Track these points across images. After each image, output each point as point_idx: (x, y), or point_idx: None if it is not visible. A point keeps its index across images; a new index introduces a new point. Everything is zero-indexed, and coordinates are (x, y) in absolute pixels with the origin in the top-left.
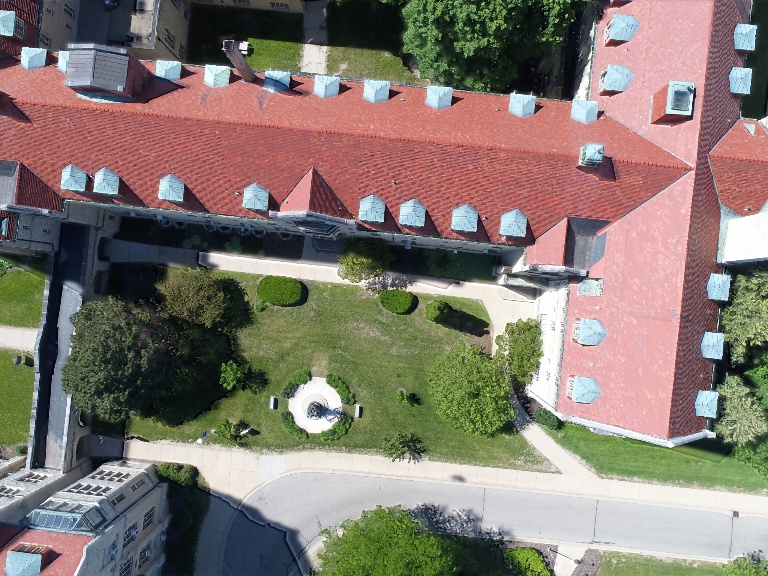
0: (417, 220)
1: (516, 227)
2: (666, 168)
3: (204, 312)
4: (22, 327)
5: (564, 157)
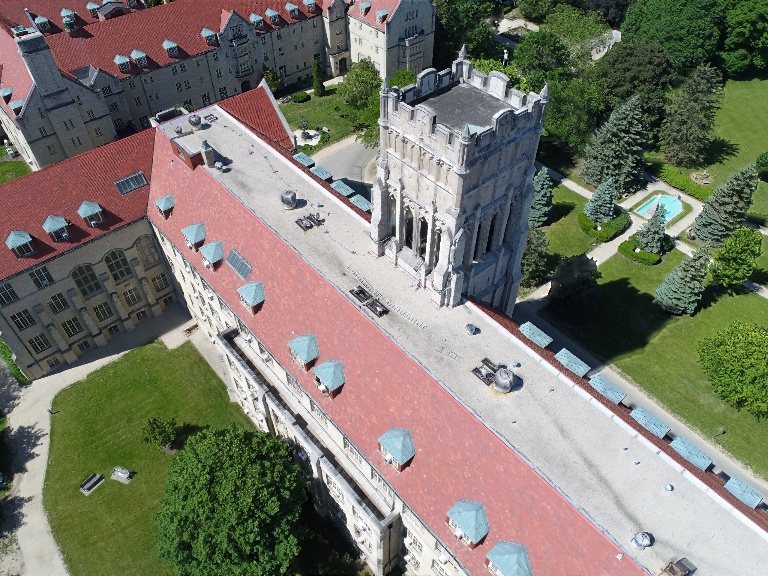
0: (275, 12)
1: None
2: None
3: None
4: None
5: None
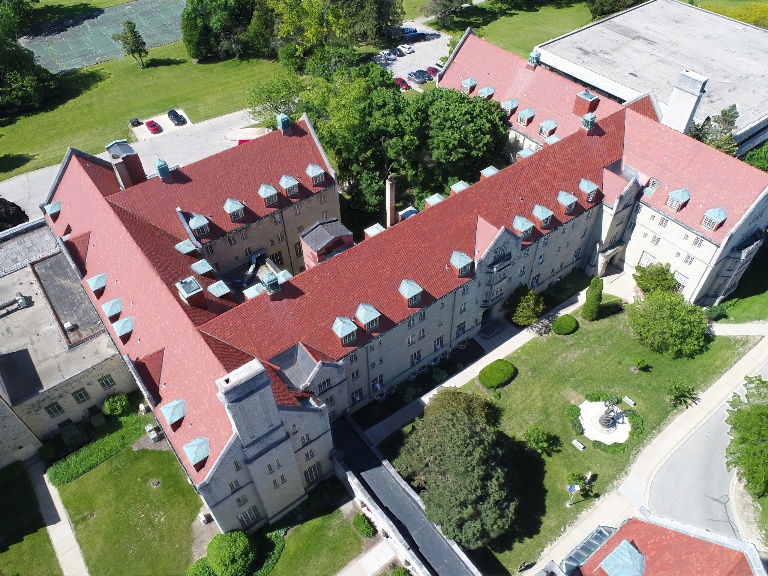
0: (548, 212)
1: (591, 185)
2: (617, 114)
3: (473, 411)
4: (340, 571)
5: (578, 133)
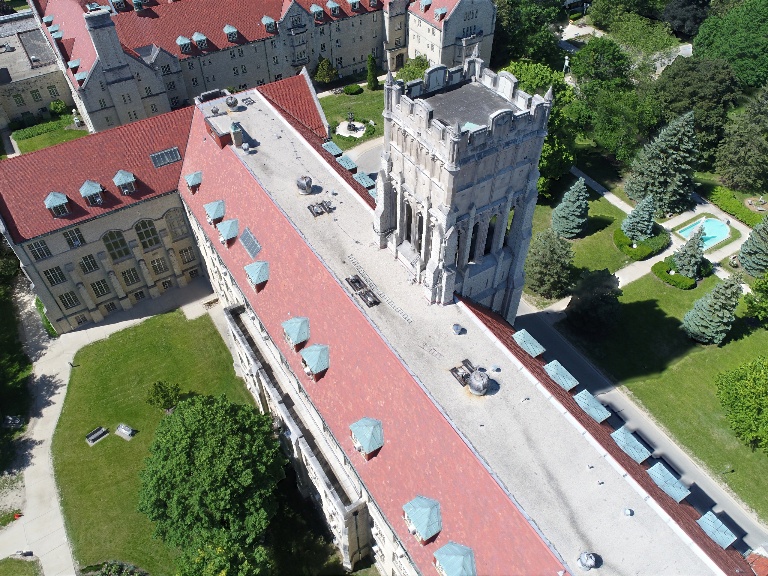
0: (336, 4)
1: None
2: None
3: None
4: None
5: None
